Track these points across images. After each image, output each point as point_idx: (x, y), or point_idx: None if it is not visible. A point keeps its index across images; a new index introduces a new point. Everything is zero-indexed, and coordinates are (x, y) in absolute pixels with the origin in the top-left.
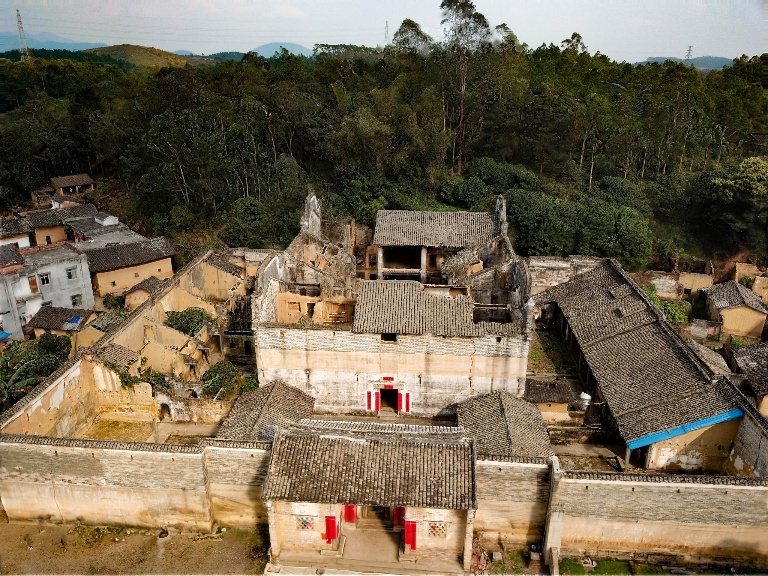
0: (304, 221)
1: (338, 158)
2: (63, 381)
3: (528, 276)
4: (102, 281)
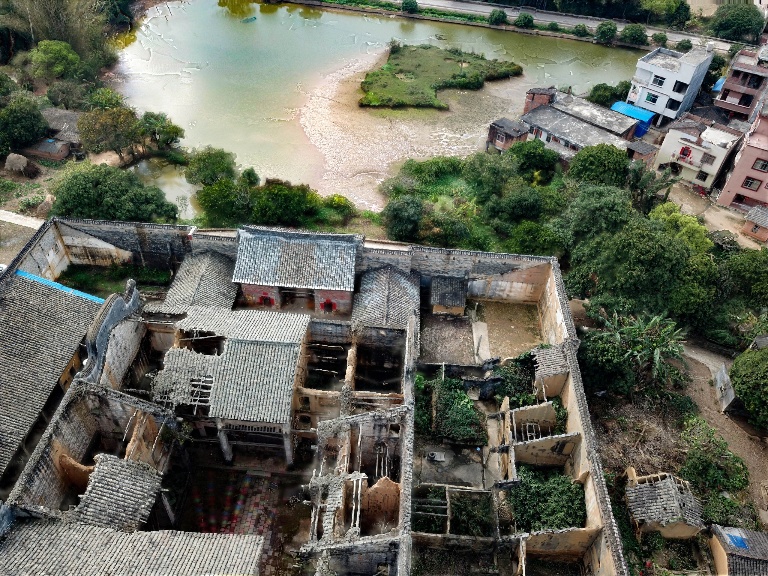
0: (402, 537)
1: None
2: None
3: None
4: None
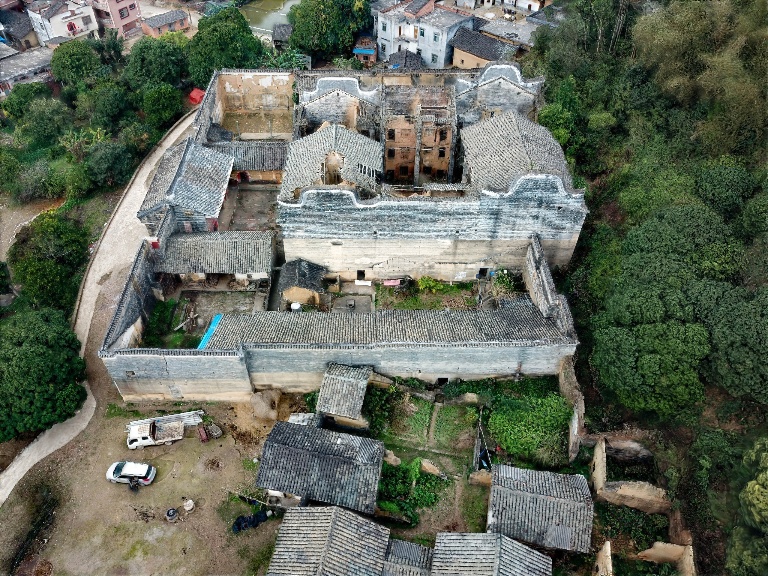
0: (459, 78)
1: (639, 49)
2: (272, 76)
3: (306, 187)
4: (456, 55)
